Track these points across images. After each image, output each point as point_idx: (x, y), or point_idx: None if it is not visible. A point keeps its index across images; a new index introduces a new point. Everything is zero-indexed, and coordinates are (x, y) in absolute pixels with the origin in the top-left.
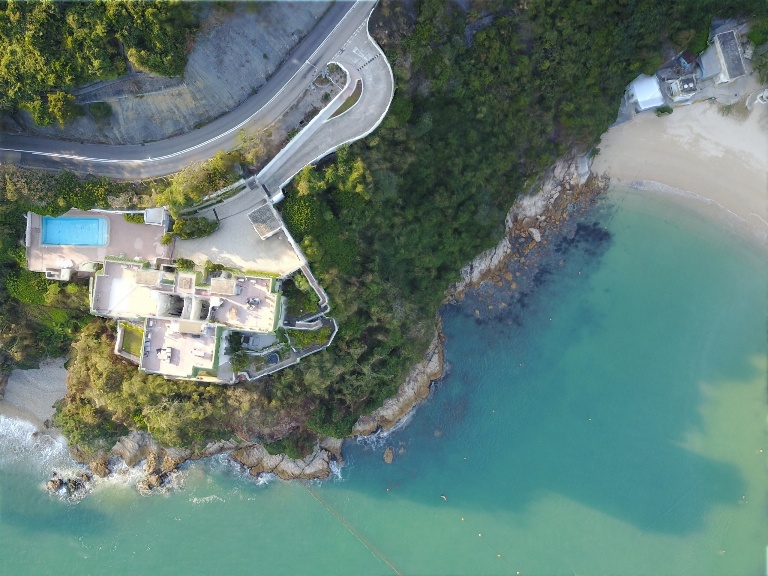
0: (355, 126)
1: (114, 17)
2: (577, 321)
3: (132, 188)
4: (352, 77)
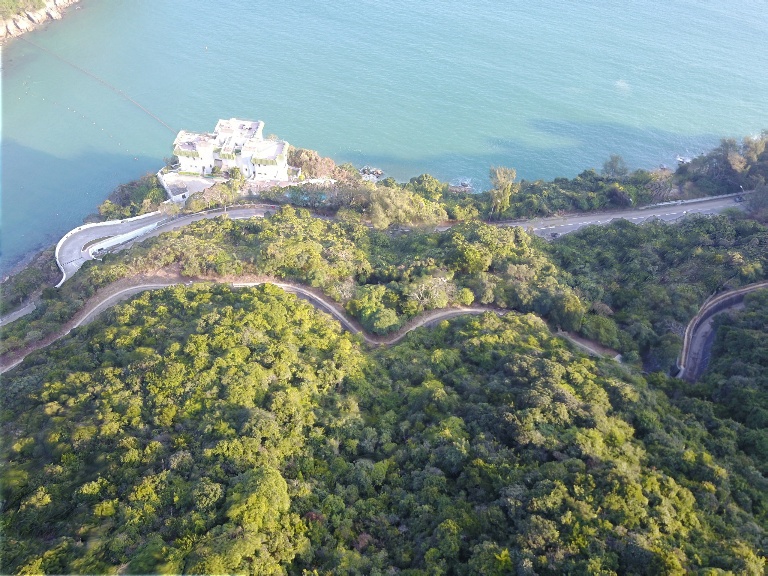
0: (98, 231)
1: (228, 220)
2: (4, 237)
3: (259, 199)
4: (88, 253)
